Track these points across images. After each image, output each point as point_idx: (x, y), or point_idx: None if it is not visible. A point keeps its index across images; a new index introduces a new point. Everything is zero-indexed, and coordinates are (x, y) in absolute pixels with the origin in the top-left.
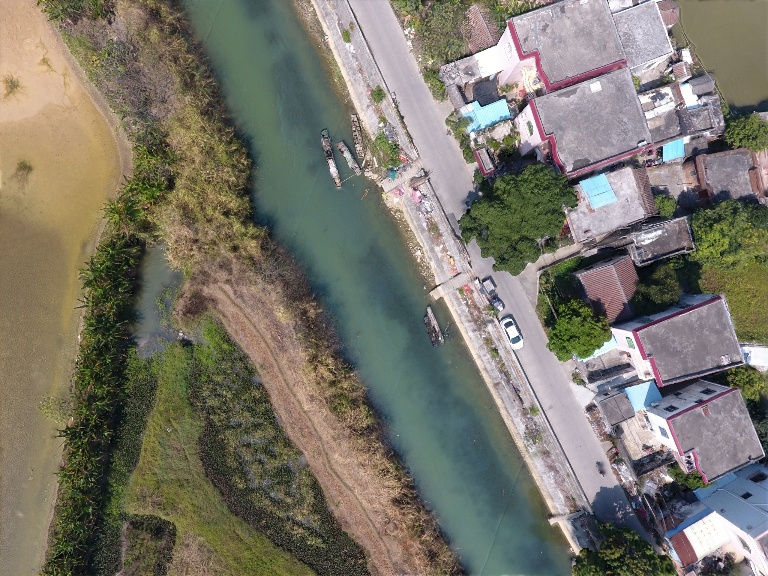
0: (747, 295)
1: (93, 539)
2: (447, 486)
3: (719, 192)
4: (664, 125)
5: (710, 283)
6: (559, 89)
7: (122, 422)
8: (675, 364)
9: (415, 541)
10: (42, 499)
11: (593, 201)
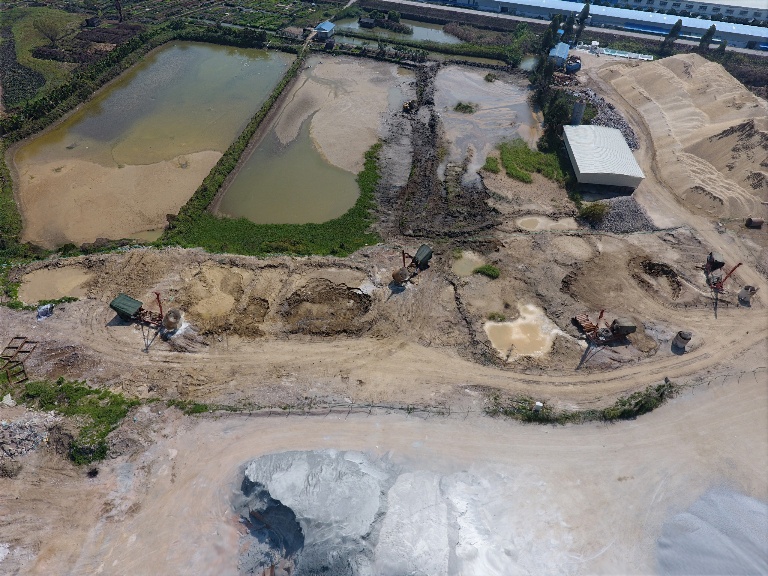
0: None
1: None
2: None
3: None
4: None
5: None
6: None
7: None
8: None
9: None
10: None
11: None
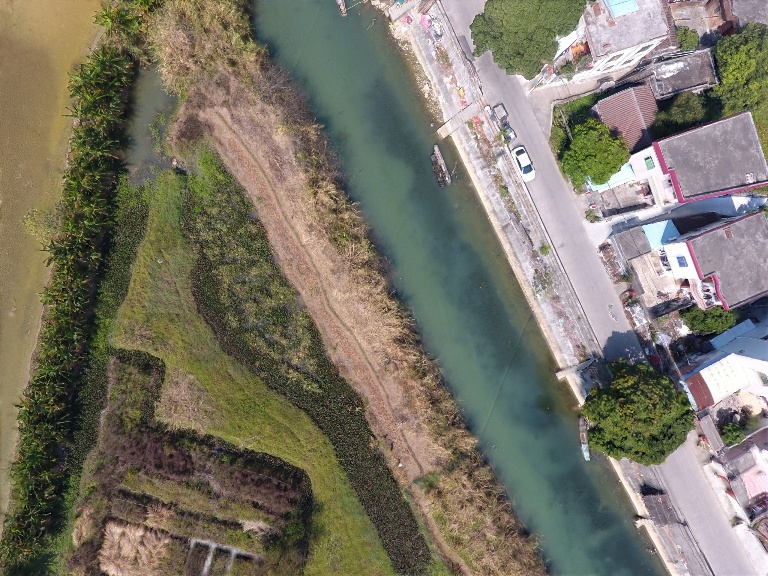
0: None
1: (78, 373)
2: (451, 334)
3: (745, 25)
4: None
5: None
6: None
7: (111, 251)
8: (697, 180)
9: (416, 381)
10: (25, 332)
11: (614, 10)
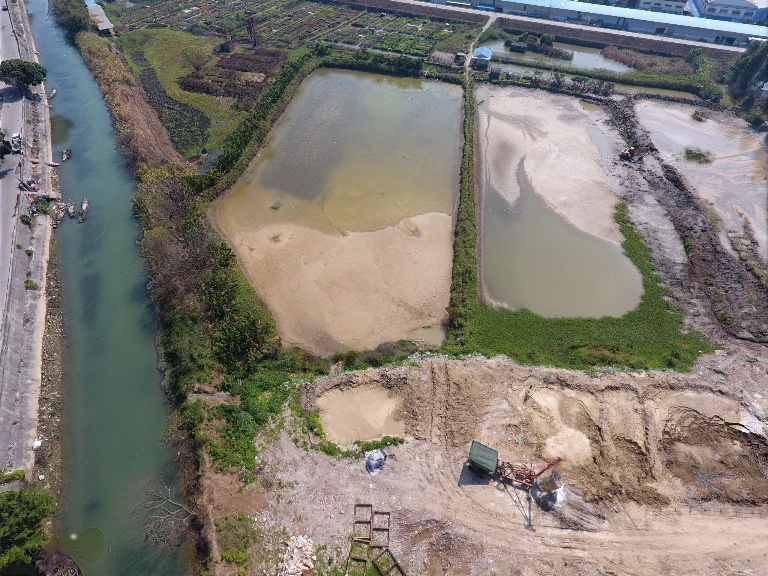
0: None
1: None
2: None
3: None
4: None
5: None
6: None
7: None
8: None
9: None
10: (289, 119)
11: None
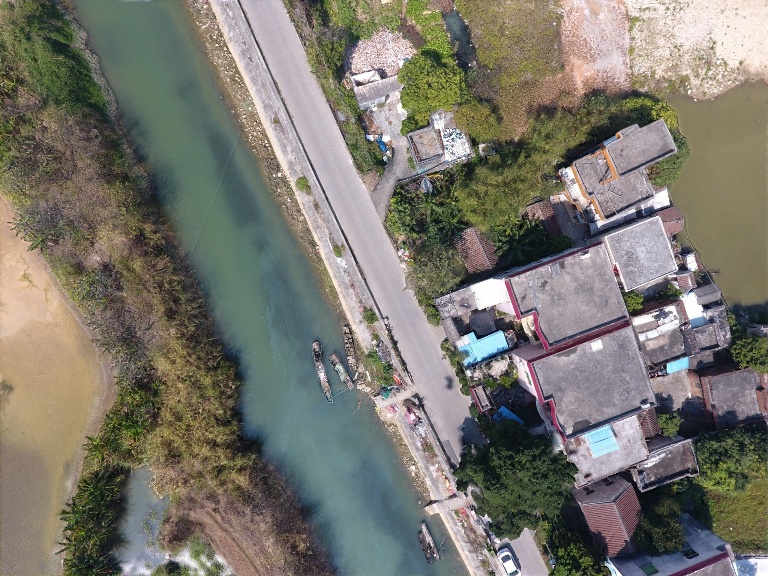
0: (753, 502)
1: None
2: None
3: (725, 412)
4: (668, 344)
5: (715, 495)
6: (558, 351)
7: None
8: None
9: None
10: None
11: (594, 449)
